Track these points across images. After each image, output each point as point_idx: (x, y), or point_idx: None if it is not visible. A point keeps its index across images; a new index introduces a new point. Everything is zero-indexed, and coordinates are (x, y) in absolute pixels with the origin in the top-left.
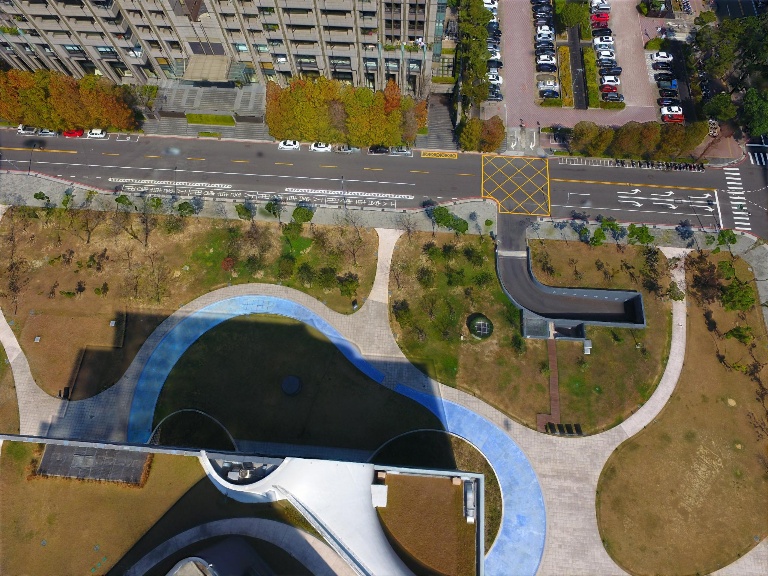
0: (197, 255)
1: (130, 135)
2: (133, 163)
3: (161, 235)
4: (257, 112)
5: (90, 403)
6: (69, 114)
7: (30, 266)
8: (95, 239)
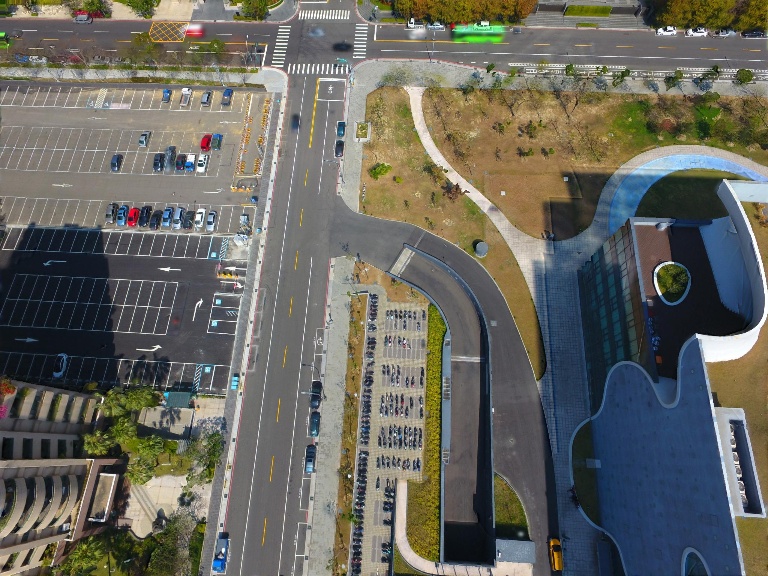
0: (618, 124)
1: (512, 27)
2: (526, 50)
3: (578, 108)
4: (624, 5)
5: (573, 242)
6: (482, 2)
7: (466, 136)
8: (518, 113)
